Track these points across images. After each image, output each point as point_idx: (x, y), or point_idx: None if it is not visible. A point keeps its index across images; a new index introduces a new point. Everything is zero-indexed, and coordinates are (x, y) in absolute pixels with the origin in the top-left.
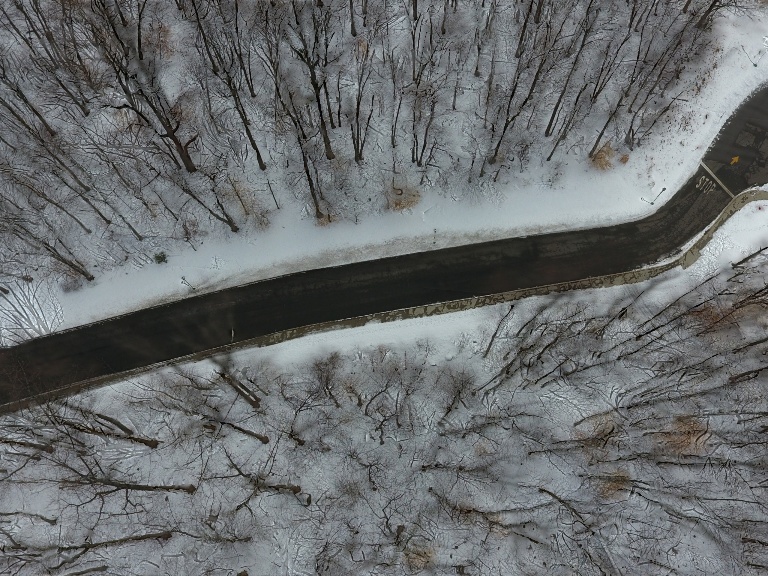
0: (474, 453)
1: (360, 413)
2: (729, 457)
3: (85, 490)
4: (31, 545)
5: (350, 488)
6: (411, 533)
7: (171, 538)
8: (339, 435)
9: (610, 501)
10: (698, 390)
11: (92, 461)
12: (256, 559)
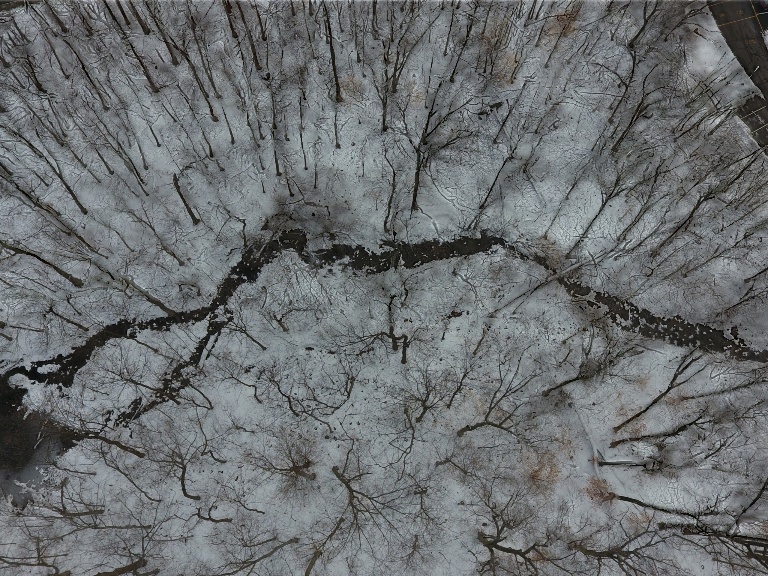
0: (400, 49)
1: (311, 19)
2: (603, 64)
3: (92, 57)
4: (50, 88)
5: (301, 71)
6: (348, 102)
7: (159, 92)
8: (294, 34)
9: (506, 89)
10: (579, 7)
11: (98, 39)
12: (225, 108)
